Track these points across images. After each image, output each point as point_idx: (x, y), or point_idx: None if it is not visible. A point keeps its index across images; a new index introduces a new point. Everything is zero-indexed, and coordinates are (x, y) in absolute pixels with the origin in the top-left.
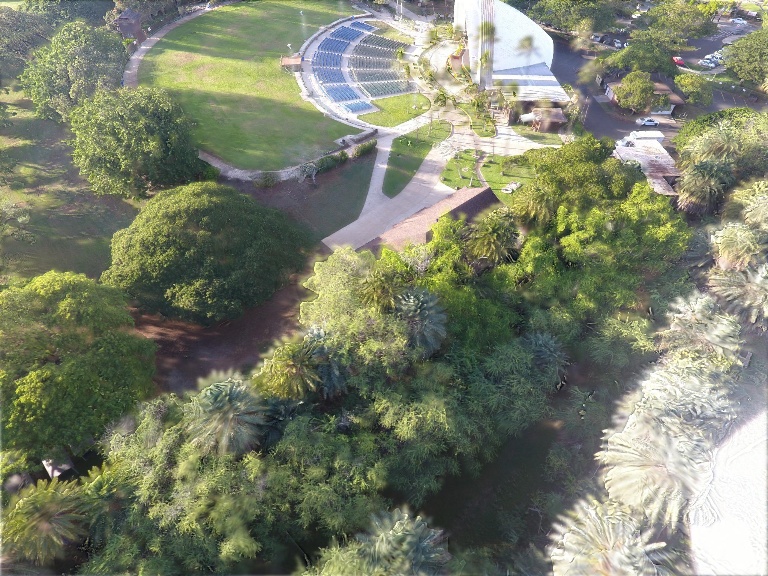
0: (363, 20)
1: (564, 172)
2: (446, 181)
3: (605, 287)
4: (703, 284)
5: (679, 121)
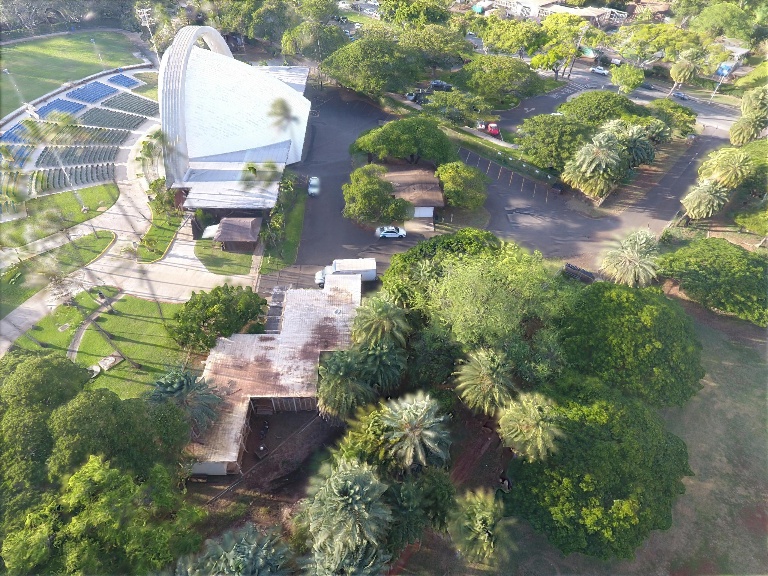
0: (134, 72)
1: None
2: None
3: None
4: None
5: (439, 228)
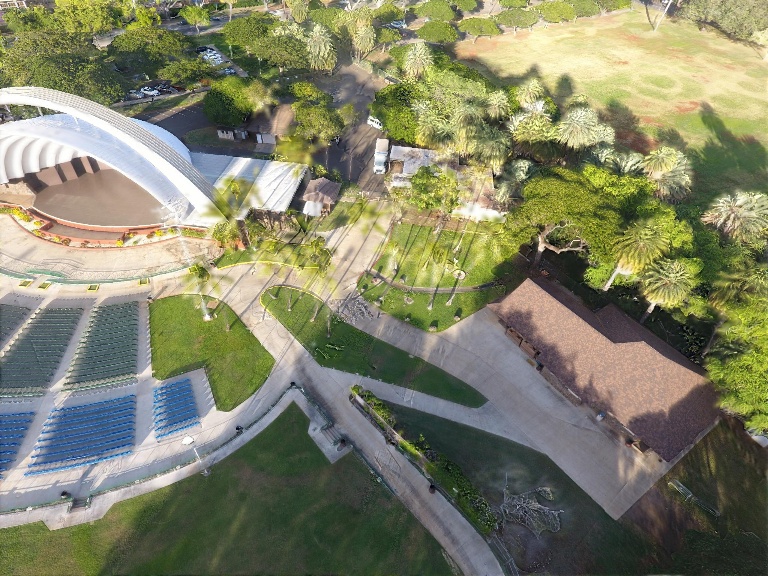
0: None
1: (582, 206)
2: (438, 326)
3: None
4: None
5: None
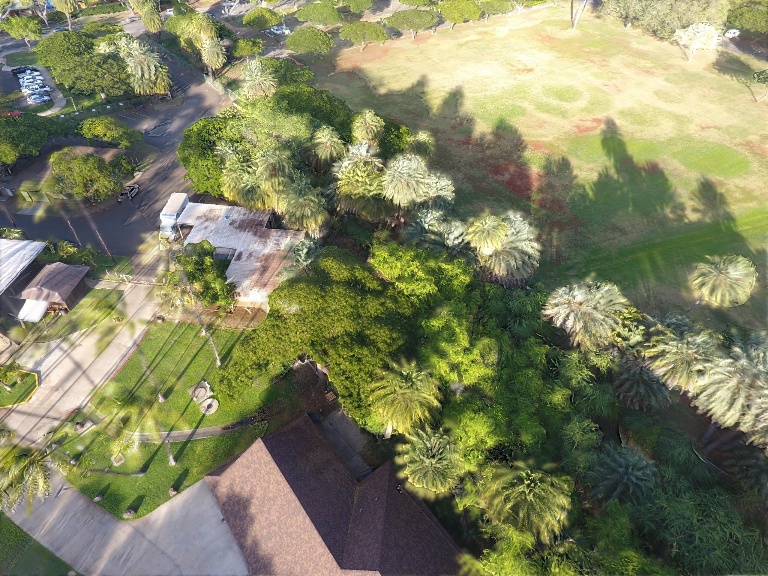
0: None
1: (337, 327)
2: (139, 508)
3: (530, 365)
4: (486, 276)
5: (141, 169)
